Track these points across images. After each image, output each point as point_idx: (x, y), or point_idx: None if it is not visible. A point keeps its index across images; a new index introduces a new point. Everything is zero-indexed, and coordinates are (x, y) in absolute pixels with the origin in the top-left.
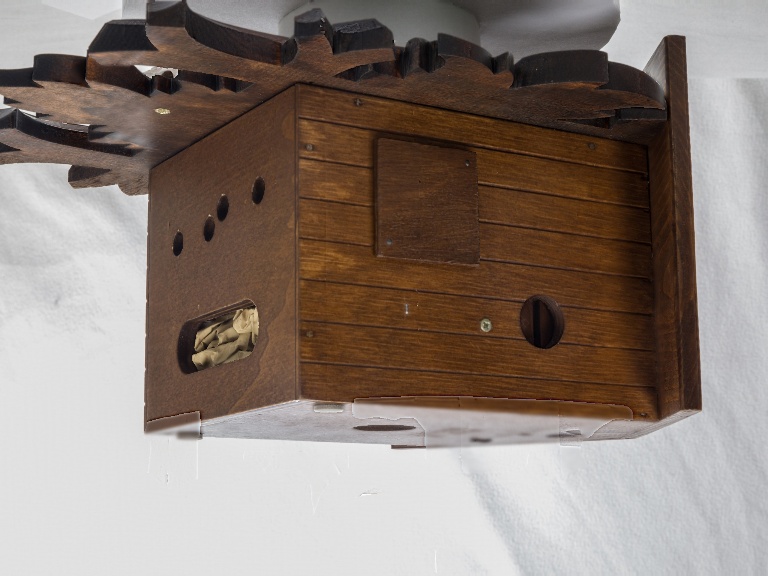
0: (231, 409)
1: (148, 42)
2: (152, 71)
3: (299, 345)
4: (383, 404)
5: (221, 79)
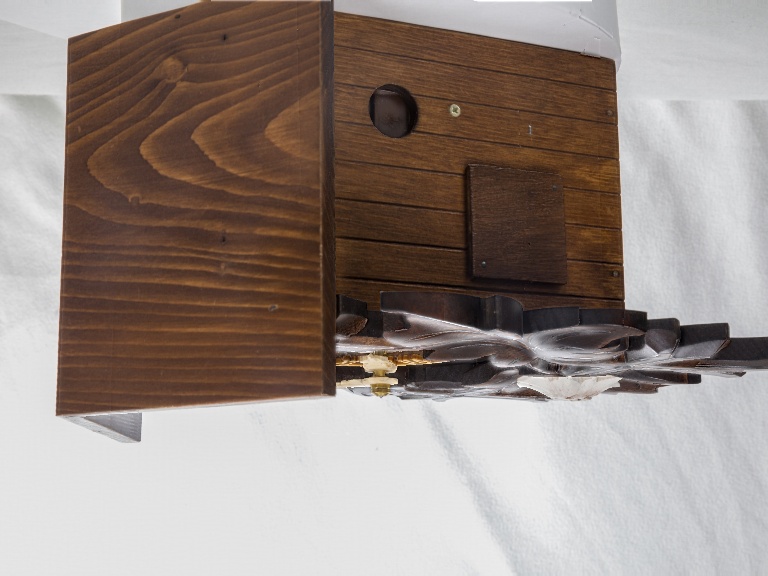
0: None
1: None
2: None
3: None
4: (609, 31)
5: None
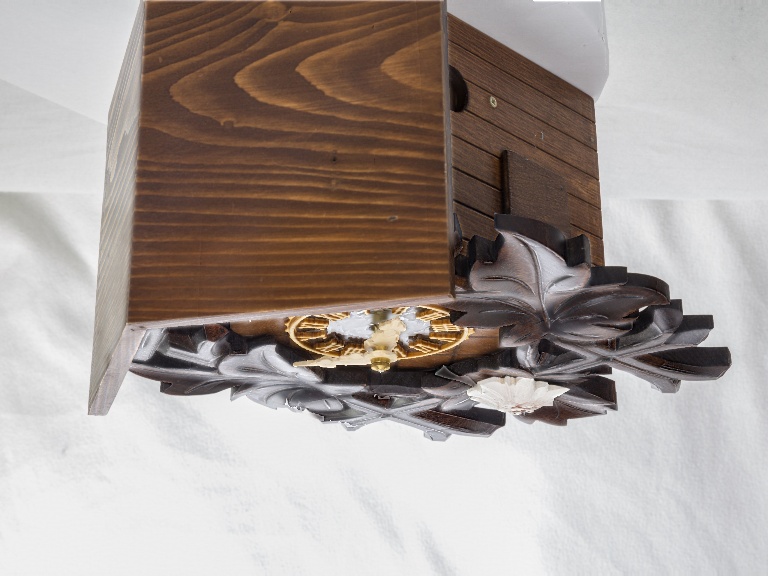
0: None
1: None
2: None
3: None
4: None
5: None
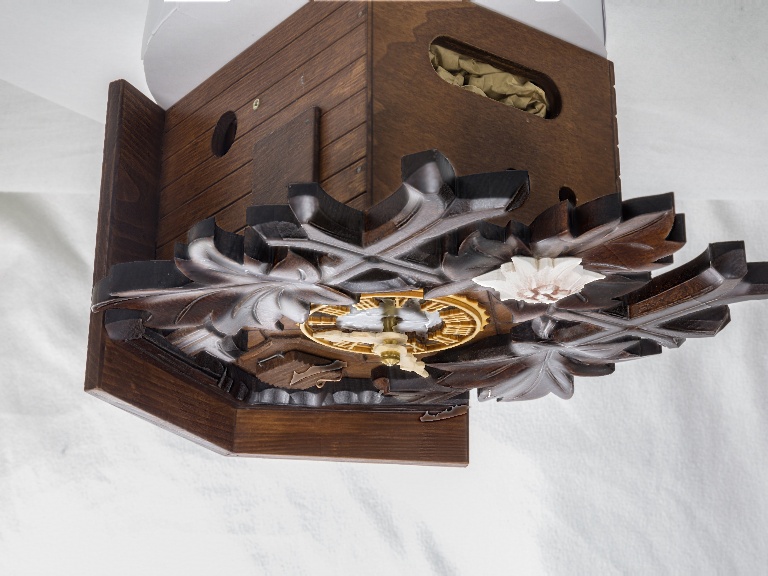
0: (470, 6)
1: (466, 183)
2: (543, 275)
3: (367, 1)
4: None
5: (449, 236)
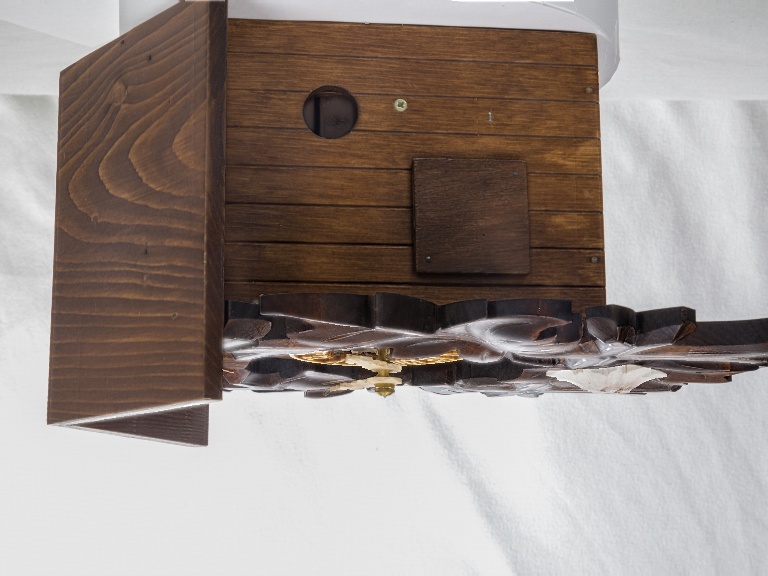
0: None
1: None
2: (641, 381)
3: None
4: (563, 5)
5: None
